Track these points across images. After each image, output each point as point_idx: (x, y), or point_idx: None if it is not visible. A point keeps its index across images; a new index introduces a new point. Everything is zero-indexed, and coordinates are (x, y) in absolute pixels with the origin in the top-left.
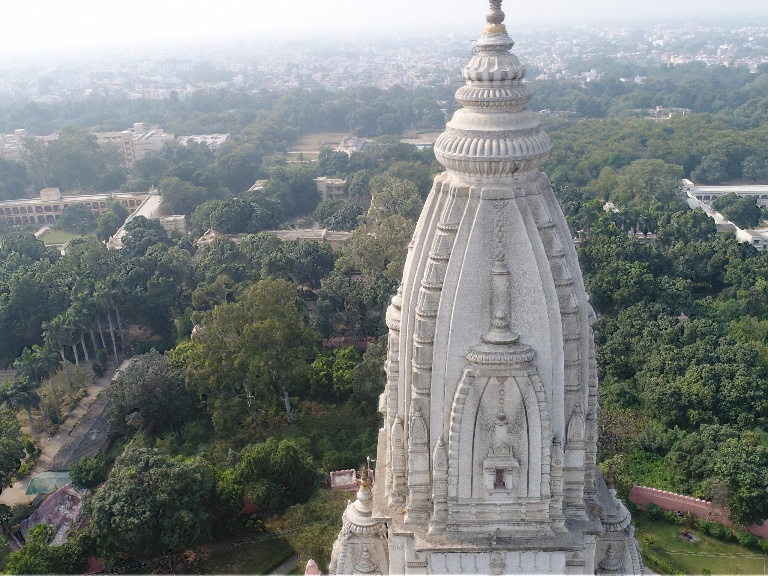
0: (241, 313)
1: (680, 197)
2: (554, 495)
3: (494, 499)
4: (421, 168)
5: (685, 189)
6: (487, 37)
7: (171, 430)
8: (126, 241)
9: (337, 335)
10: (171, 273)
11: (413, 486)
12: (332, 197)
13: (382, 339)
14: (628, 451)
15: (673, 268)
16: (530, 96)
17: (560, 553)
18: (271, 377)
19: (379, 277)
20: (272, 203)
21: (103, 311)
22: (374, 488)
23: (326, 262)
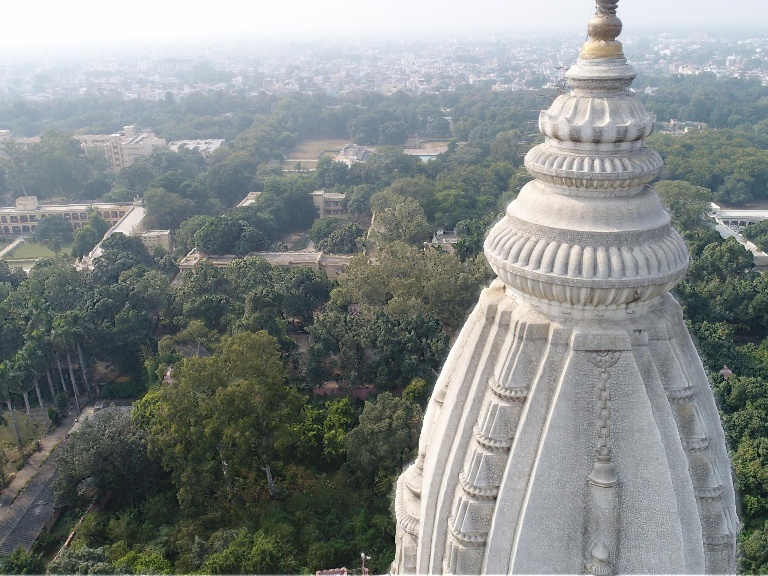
0: (215, 370)
1: (708, 223)
2: None
3: None
4: (426, 185)
5: (711, 213)
6: (589, 64)
7: (131, 502)
8: (97, 264)
9: (330, 381)
10: (146, 302)
11: None
12: (330, 212)
13: (382, 398)
14: None
15: (709, 309)
16: (659, 168)
17: None
18: (249, 445)
19: (379, 315)
20: (264, 220)
21: (61, 352)
22: None
23: (320, 291)
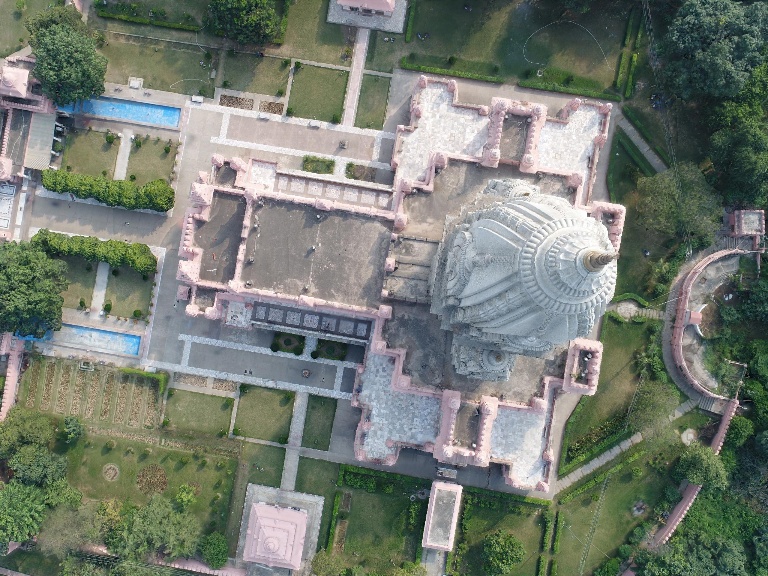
0: None
1: None
2: None
3: None
4: None
5: None
6: (587, 253)
7: None
8: None
9: None
10: None
11: None
12: None
13: None
14: (762, 514)
15: None
16: None
17: None
18: None
19: None
20: None
21: None
22: (506, 198)
23: None
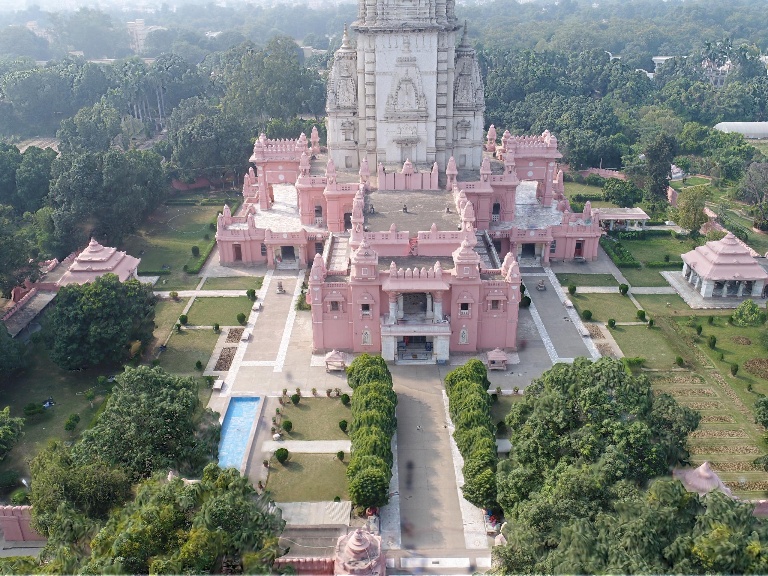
0: (261, 60)
1: None
2: (431, 5)
3: (404, 5)
4: None
5: None
6: None
7: None
8: (159, 60)
9: None
10: None
11: (369, 5)
12: None
13: None
14: None
15: None
16: None
17: (435, 36)
18: (280, 108)
19: None
20: None
21: (154, 86)
22: None
23: None
